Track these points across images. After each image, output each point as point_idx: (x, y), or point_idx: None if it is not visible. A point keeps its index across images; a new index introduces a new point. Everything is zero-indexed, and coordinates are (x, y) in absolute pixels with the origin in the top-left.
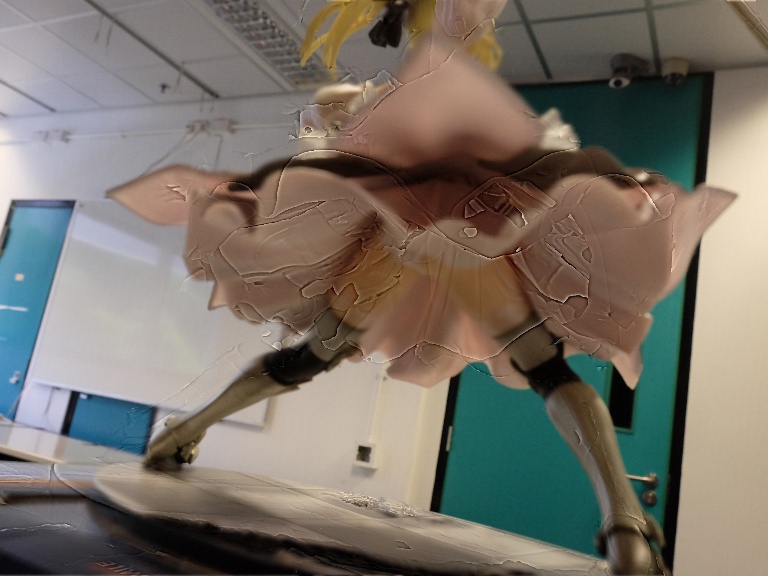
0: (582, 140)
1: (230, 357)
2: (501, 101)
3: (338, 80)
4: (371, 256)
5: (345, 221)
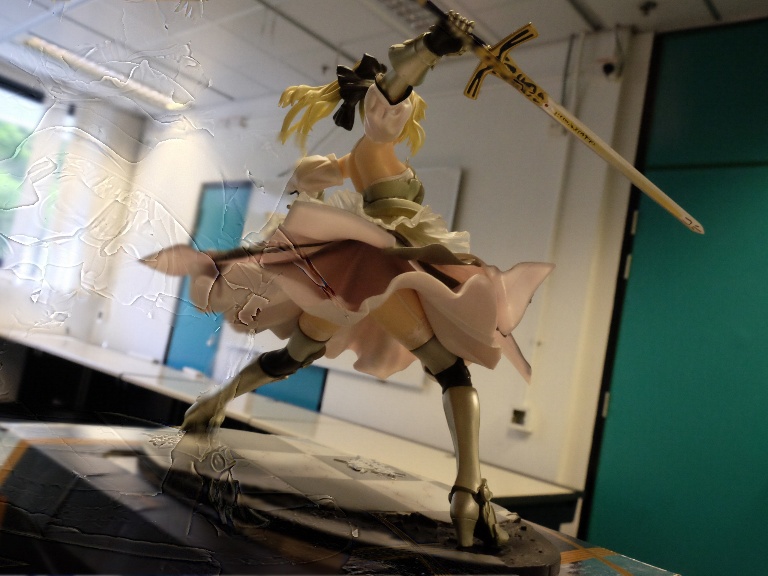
0: (171, 92)
1: (10, 310)
2: None
3: (83, 55)
4: (141, 216)
5: (110, 185)
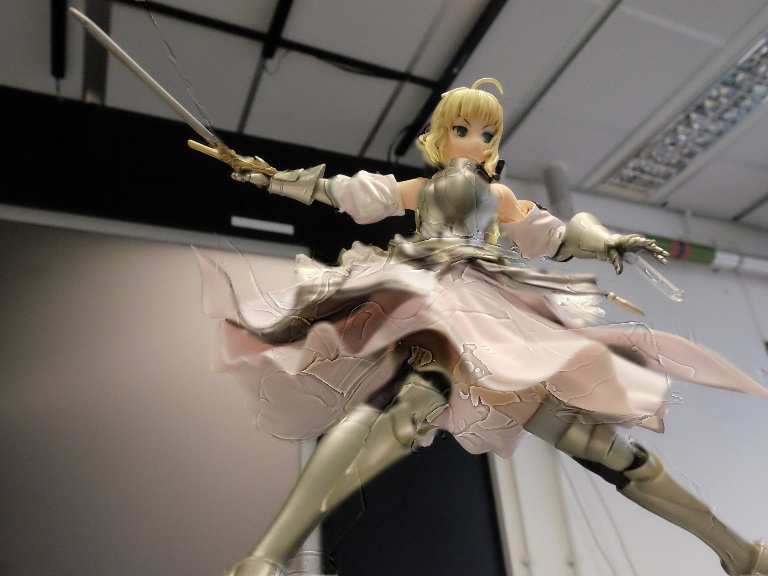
0: None
1: None
2: (264, 385)
3: None
4: None
5: None
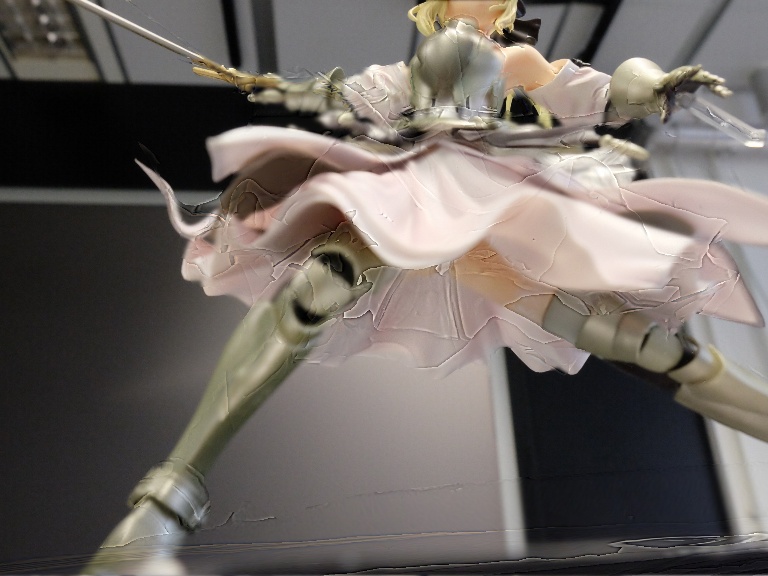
0: None
1: None
2: None
3: None
4: None
5: None
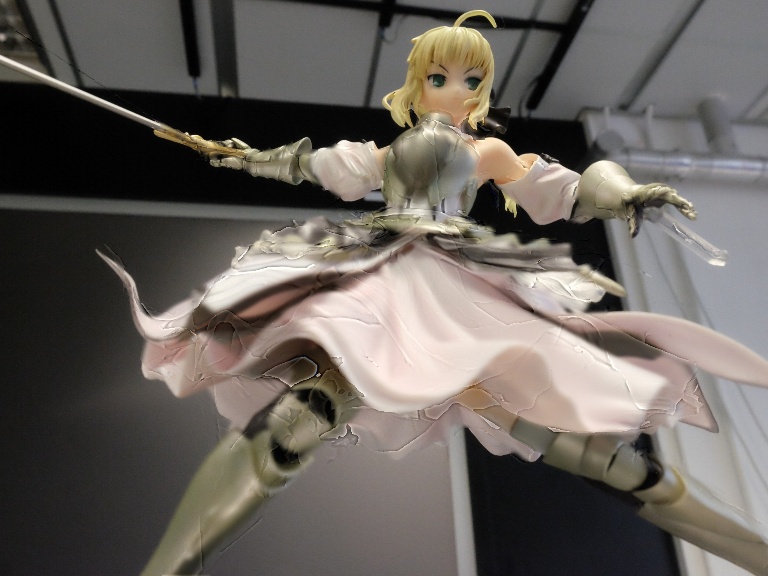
0: None
1: None
2: (245, 387)
3: None
4: None
5: None
